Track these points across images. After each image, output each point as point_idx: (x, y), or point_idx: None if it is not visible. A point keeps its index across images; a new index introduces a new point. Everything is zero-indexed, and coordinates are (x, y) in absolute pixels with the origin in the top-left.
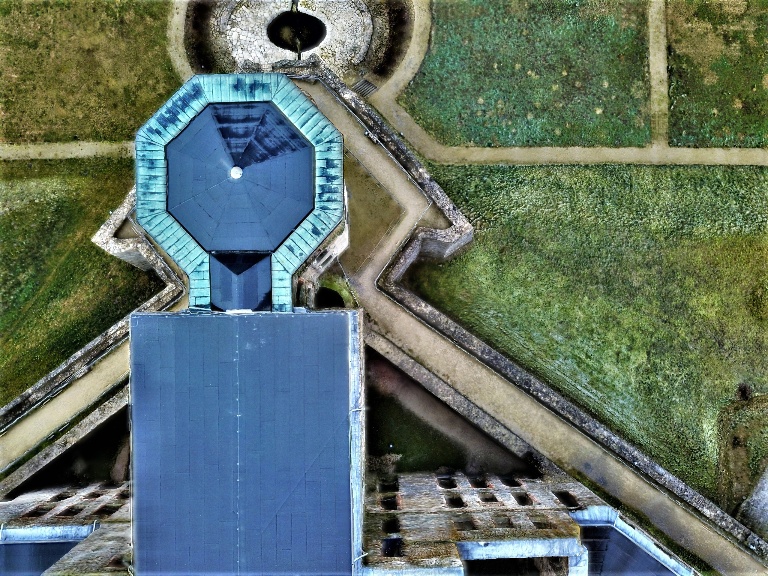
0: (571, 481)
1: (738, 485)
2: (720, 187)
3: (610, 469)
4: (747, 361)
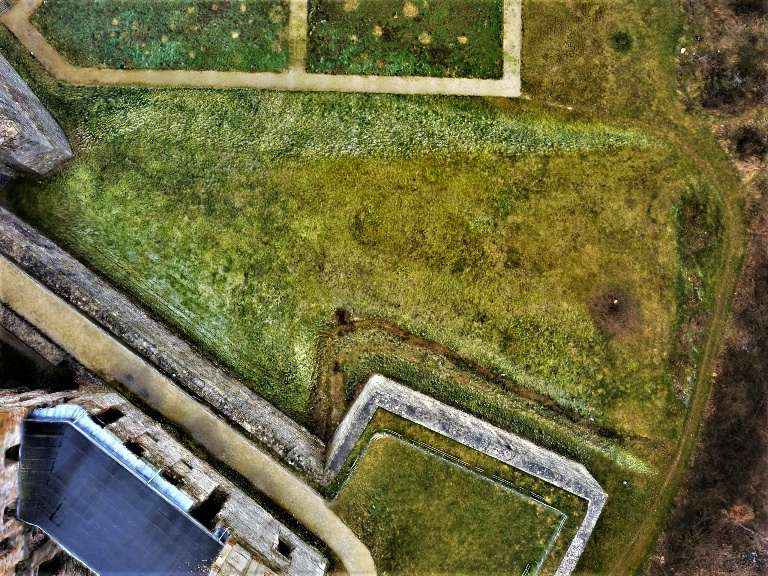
0: (106, 391)
1: (336, 411)
2: (349, 113)
3: (153, 381)
4: (347, 285)
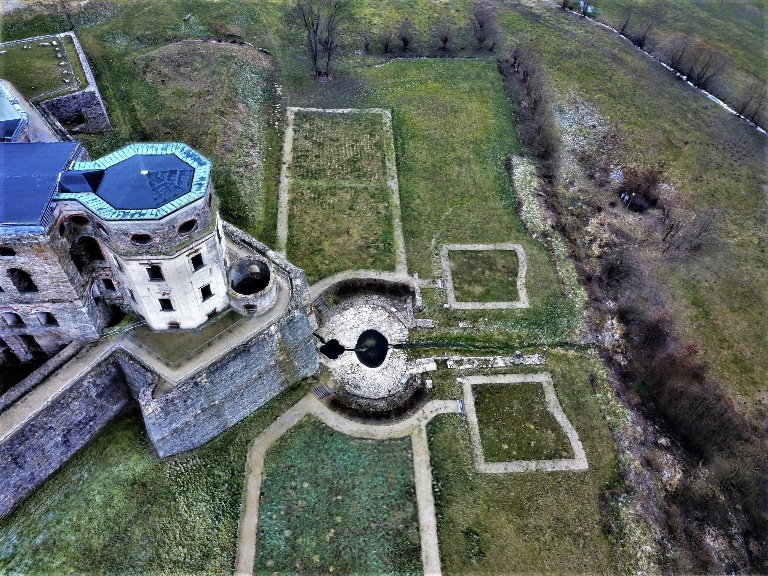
0: None
1: None
2: None
3: None
4: None
